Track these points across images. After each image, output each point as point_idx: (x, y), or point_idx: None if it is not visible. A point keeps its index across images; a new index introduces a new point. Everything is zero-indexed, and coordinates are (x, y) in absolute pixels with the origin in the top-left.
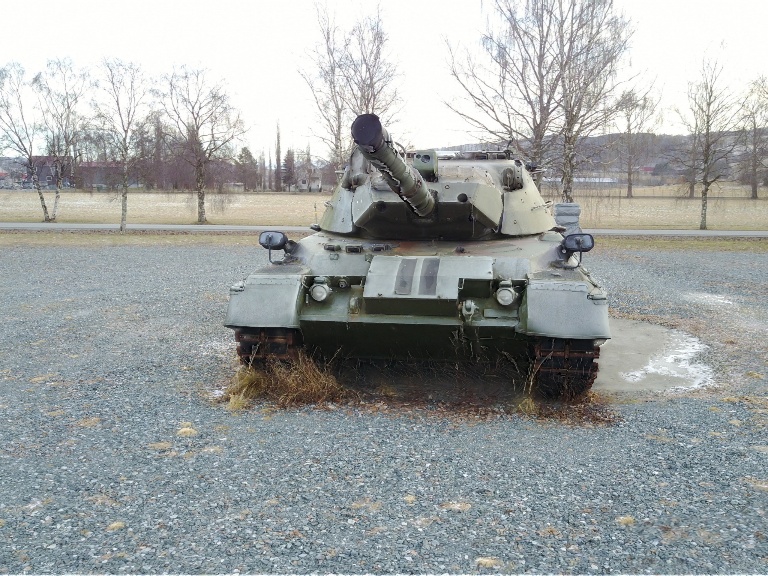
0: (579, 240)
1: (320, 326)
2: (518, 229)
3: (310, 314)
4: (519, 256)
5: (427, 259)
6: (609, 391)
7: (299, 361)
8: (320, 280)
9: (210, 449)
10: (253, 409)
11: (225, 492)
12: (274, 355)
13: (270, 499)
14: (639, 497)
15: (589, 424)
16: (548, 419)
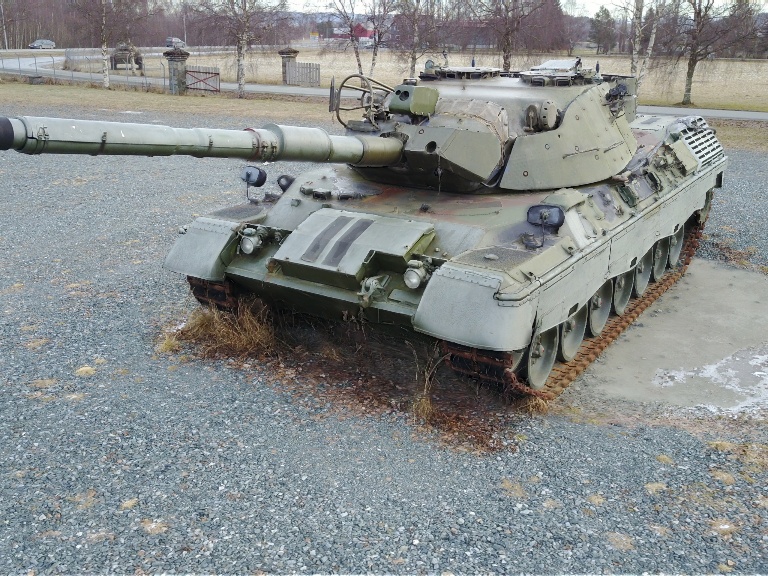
0: (542, 214)
1: (247, 280)
2: (530, 182)
3: (236, 267)
4: (478, 224)
5: (362, 220)
6: (604, 395)
7: (237, 311)
8: (247, 232)
9: (73, 396)
10: (177, 354)
11: (6, 451)
12: (212, 302)
13: (24, 470)
14: (342, 572)
15: (467, 446)
16: (432, 429)
